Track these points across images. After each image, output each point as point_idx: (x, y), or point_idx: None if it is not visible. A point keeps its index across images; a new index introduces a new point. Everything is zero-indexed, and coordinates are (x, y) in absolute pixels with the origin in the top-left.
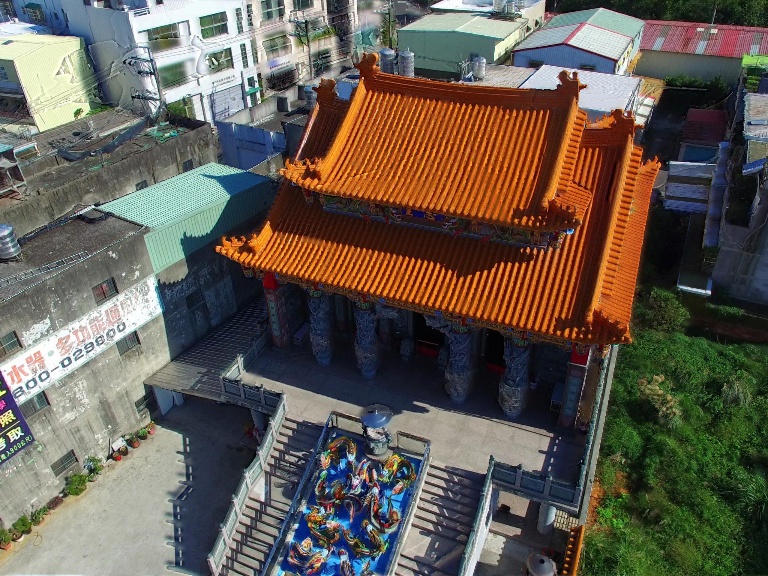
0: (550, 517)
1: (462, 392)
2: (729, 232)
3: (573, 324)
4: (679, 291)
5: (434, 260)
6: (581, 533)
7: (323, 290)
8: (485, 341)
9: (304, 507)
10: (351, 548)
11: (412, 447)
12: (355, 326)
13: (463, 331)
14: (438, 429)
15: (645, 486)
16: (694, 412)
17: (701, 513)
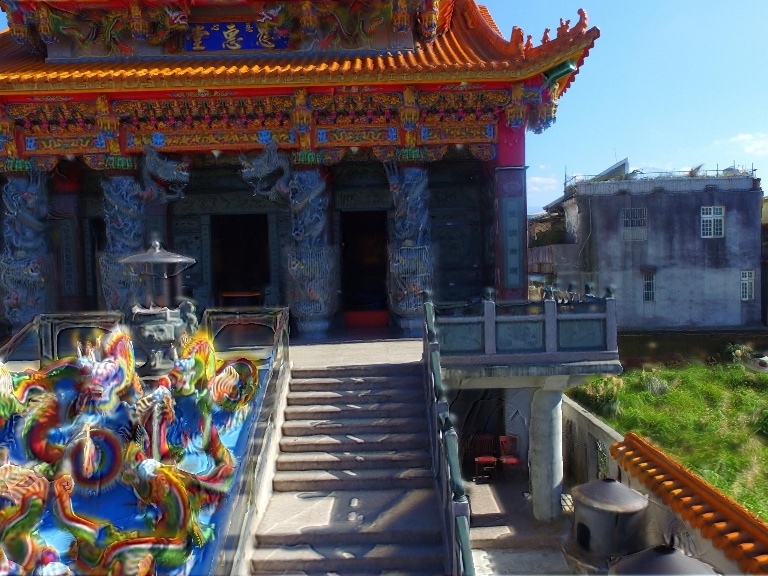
0: (557, 459)
1: (322, 306)
2: (560, 252)
3: None
4: None
5: (248, 65)
6: None
7: (36, 161)
8: (340, 260)
9: None
10: (84, 568)
11: None
12: (99, 311)
13: (313, 161)
14: (290, 353)
15: None
16: (632, 399)
17: None
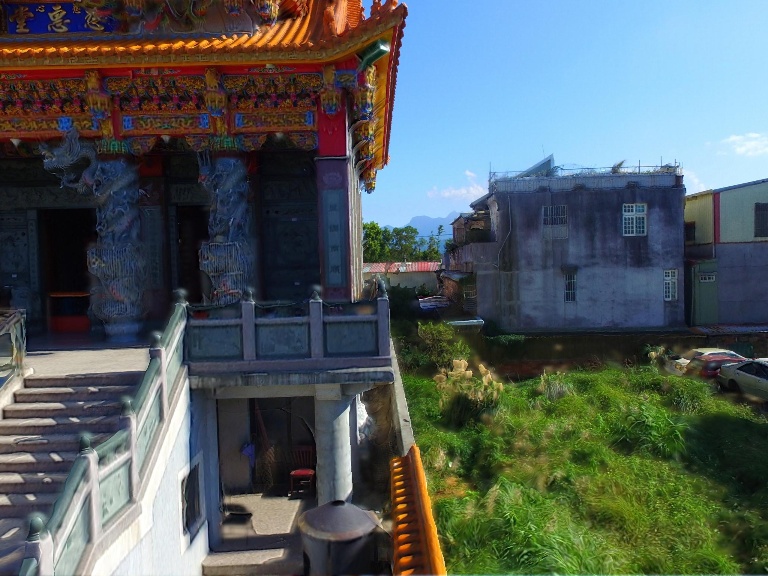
0: (341, 475)
1: (128, 307)
2: (479, 251)
3: None
4: (449, 325)
5: None
6: (414, 452)
7: None
8: (176, 258)
9: None
10: None
11: None
12: None
13: (117, 150)
14: (66, 359)
15: (498, 469)
16: (520, 404)
17: (601, 462)
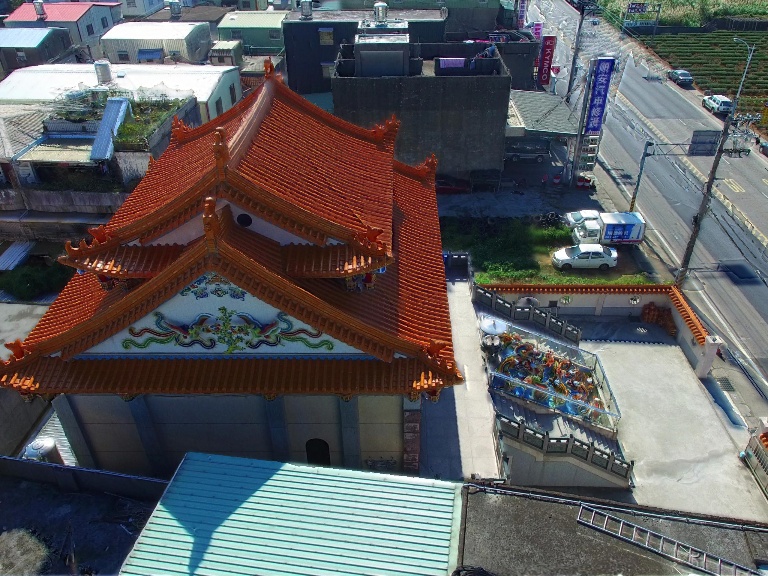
0: None
1: None
2: None
3: (425, 183)
4: None
5: None
6: None
7: None
8: None
9: (554, 408)
10: None
11: (475, 341)
12: None
13: None
14: None
15: None
16: None
17: None
